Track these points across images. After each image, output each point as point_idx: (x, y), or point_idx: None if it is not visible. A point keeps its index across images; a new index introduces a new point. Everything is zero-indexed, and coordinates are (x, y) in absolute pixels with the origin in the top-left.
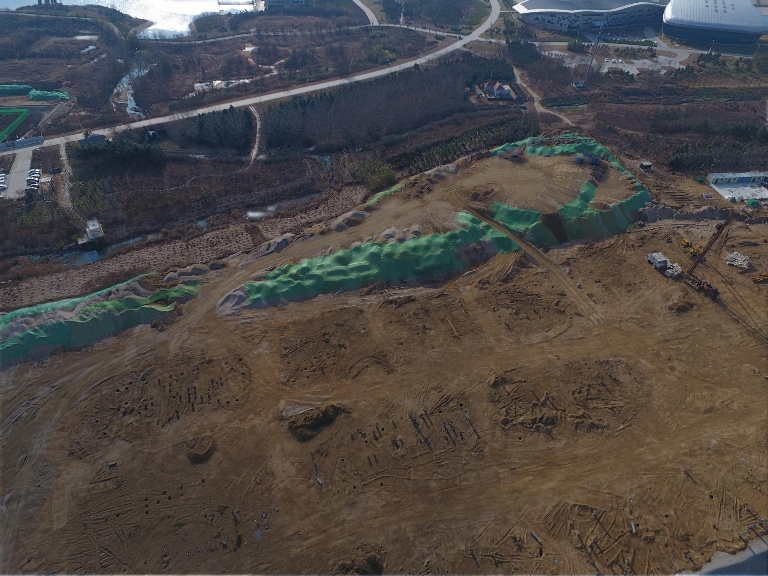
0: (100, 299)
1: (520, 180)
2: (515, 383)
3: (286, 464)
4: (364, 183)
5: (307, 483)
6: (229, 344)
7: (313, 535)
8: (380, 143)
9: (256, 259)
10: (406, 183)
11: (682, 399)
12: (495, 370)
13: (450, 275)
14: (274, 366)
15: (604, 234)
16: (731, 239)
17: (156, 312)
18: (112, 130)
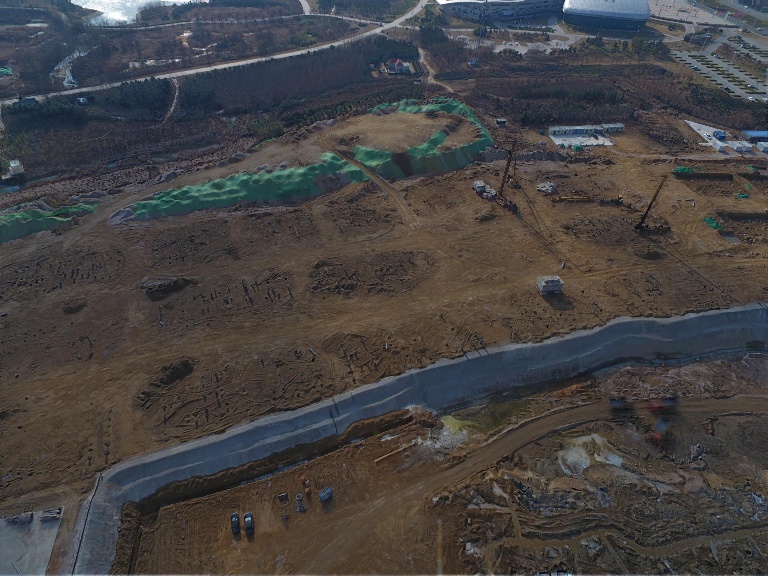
0: (10, 211)
1: (384, 130)
2: (333, 265)
3: (138, 314)
4: (256, 135)
5: (151, 324)
6: (112, 243)
7: (147, 352)
8: (279, 106)
9: (148, 187)
10: (288, 133)
11: (458, 274)
12: (320, 258)
13: (307, 198)
14: (145, 256)
15: (445, 170)
16: (549, 173)
17: (56, 221)
18: (45, 96)
